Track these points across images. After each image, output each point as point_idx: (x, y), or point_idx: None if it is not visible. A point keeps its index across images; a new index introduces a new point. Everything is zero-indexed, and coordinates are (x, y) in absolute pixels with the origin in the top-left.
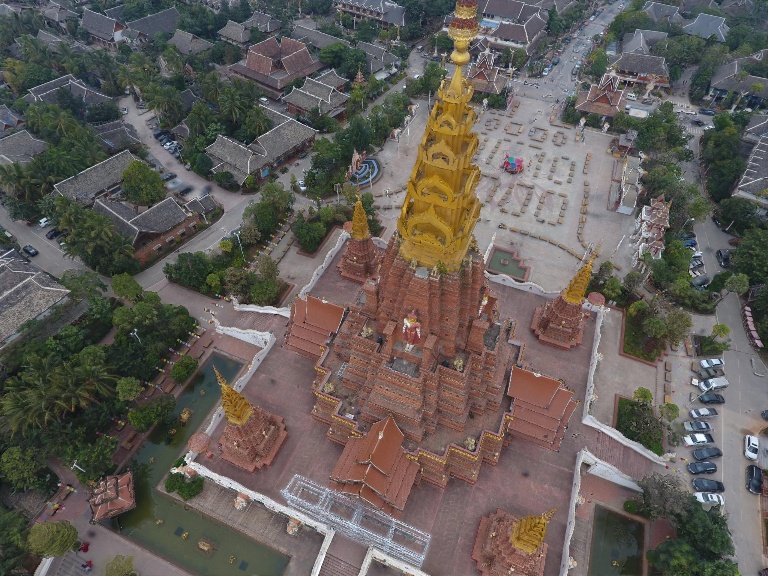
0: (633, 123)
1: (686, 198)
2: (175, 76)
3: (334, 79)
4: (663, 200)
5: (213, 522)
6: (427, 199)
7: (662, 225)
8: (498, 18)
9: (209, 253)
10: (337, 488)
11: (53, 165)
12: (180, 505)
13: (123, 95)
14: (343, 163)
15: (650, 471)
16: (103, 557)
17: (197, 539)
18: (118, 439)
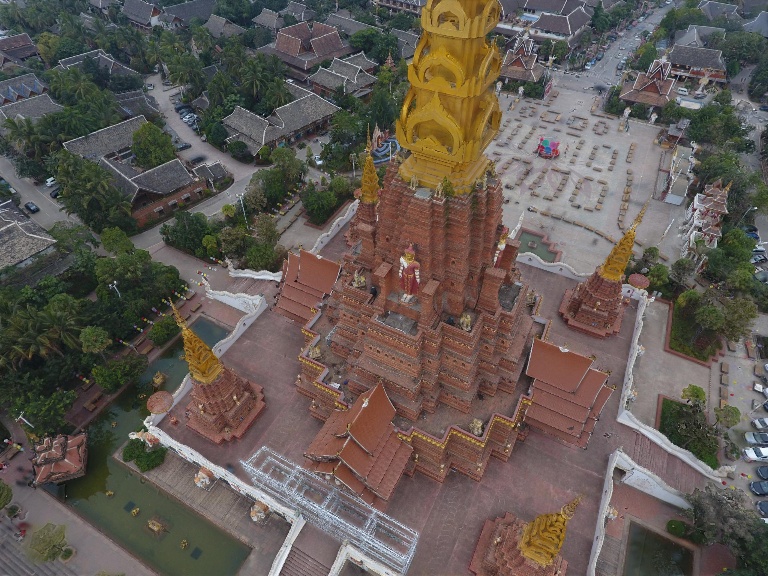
0: (685, 113)
1: (747, 187)
2: (202, 52)
3: (363, 62)
4: (720, 185)
5: (170, 499)
6: (431, 85)
7: (719, 211)
8: (539, 13)
9: (210, 217)
10: (311, 467)
11: (65, 123)
12: (136, 477)
13: (152, 73)
14: (364, 140)
15: (701, 487)
16: (39, 527)
17: (148, 517)
18: (82, 399)
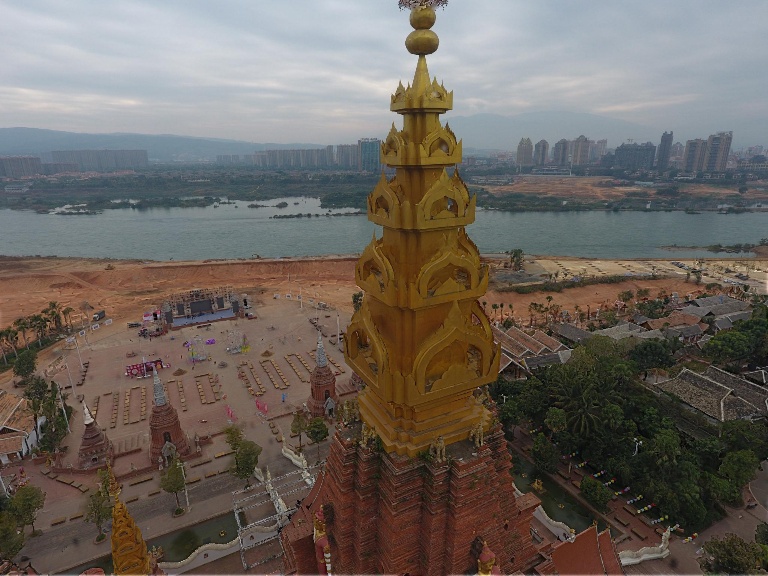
0: None
1: None
2: None
3: None
4: None
5: None
6: None
7: None
8: None
9: None
10: None
11: None
12: None
13: None
14: None
15: None
16: None
17: None
18: None
